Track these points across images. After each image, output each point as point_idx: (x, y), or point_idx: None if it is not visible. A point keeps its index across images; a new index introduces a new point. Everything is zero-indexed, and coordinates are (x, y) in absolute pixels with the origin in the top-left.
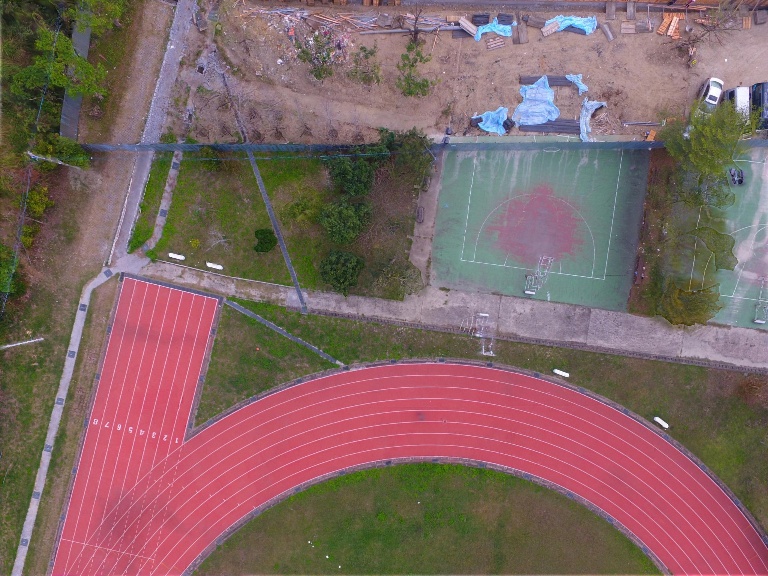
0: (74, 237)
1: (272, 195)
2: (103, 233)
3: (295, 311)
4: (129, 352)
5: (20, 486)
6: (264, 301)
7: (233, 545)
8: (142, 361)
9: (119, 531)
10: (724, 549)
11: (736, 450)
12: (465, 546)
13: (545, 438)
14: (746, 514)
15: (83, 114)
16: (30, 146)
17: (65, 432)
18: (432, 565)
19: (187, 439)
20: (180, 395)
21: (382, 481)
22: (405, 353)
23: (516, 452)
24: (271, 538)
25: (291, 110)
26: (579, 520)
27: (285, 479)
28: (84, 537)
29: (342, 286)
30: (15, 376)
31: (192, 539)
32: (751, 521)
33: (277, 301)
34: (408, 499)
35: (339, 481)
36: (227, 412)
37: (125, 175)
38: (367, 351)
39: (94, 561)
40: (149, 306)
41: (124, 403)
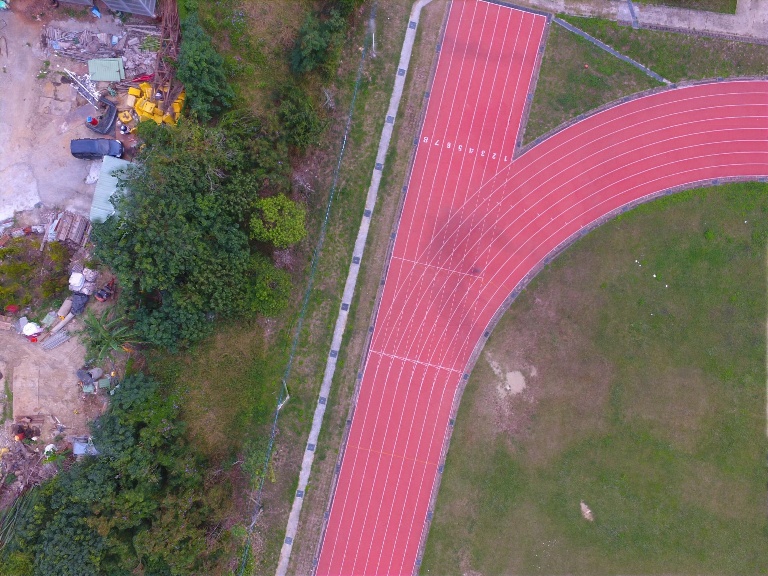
0: None
1: None
2: None
3: (626, 25)
4: (459, 69)
5: (352, 203)
6: (594, 16)
7: (561, 264)
8: (471, 79)
9: (449, 249)
10: None
11: None
12: None
13: None
14: None
15: None
16: None
17: (396, 150)
18: (759, 284)
19: (515, 158)
20: (509, 113)
21: (709, 200)
22: (733, 70)
23: None
24: (598, 257)
25: None
26: None
27: (612, 198)
28: (414, 255)
29: None
30: (348, 93)
31: (520, 258)
32: None
33: (608, 15)
34: (735, 218)
35: (666, 200)
36: (554, 131)
37: None
38: (695, 68)
39: (424, 279)
40: (478, 23)
41: (454, 121)
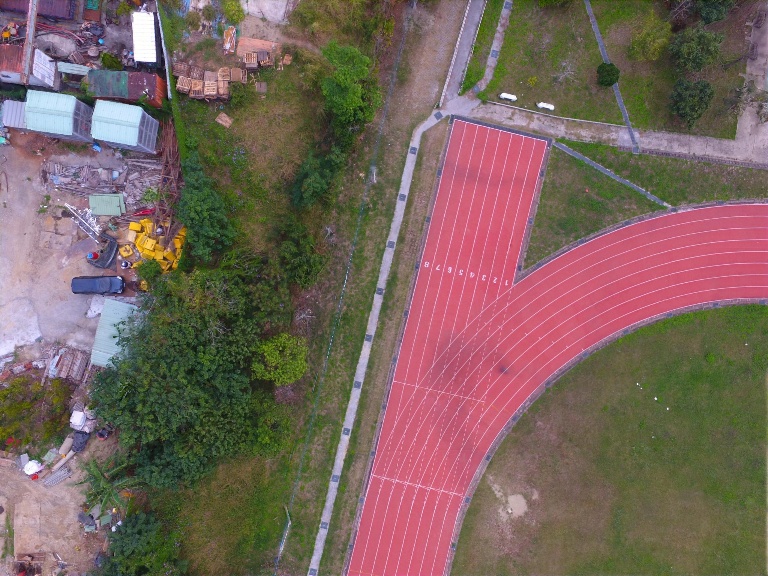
0: (406, 79)
1: (605, 33)
2: (434, 75)
3: (627, 151)
4: (460, 194)
5: (354, 328)
6: (595, 142)
7: (562, 387)
8: (472, 204)
9: (450, 373)
10: None
11: None
12: None
13: None
14: None
15: None
16: None
17: (397, 275)
18: (759, 407)
19: (516, 282)
20: (509, 237)
21: (710, 323)
22: (733, 194)
23: None
24: (599, 380)
25: None
26: None
27: (613, 321)
28: (416, 379)
29: (695, 115)
30: (349, 219)
31: (521, 381)
32: None
33: (608, 141)
34: (736, 341)
35: (667, 323)
36: (555, 255)
37: (457, 16)
38: (695, 192)
39: (426, 403)
40: (479, 148)
41: (455, 246)
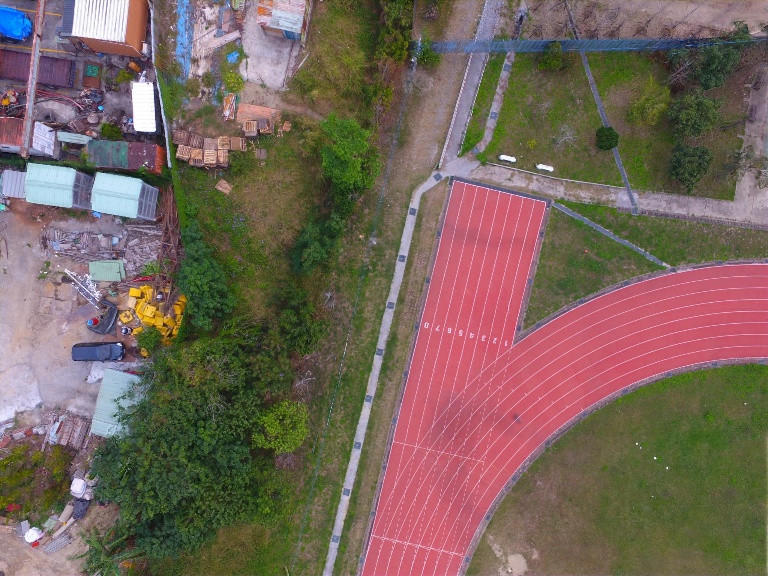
0: (406, 141)
1: (604, 95)
2: (434, 137)
3: (626, 212)
4: (459, 255)
5: (354, 389)
6: (594, 203)
7: (562, 447)
8: (472, 264)
9: (450, 434)
10: None
11: None
12: None
13: None
14: None
15: (416, 16)
16: (387, 42)
17: (396, 336)
18: (759, 466)
19: (516, 342)
20: (509, 298)
21: (709, 382)
22: (732, 254)
23: None
24: (599, 440)
25: (624, 9)
26: None
27: (612, 381)
28: (416, 440)
29: (694, 180)
30: (349, 280)
31: (521, 441)
32: None
33: (607, 202)
34: (735, 400)
35: (666, 383)
36: (555, 315)
37: (457, 78)
38: (694, 252)
39: (426, 464)
40: (478, 209)
41: (454, 306)
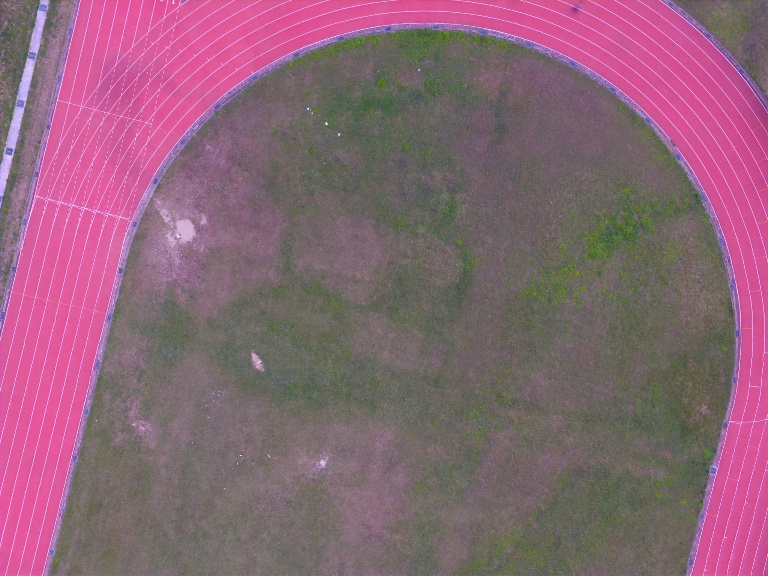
0: None
1: None
2: None
3: None
4: None
5: (15, 45)
6: None
7: (231, 110)
8: None
9: (116, 94)
10: (728, 119)
11: (741, 16)
12: (466, 115)
13: (547, 4)
14: (751, 84)
15: None
16: None
17: None
18: (432, 134)
19: (184, 1)
20: None
21: (382, 47)
22: None
23: (518, 19)
24: (270, 104)
25: None
26: (581, 89)
27: (283, 44)
28: (81, 99)
29: None
30: None
31: (190, 104)
32: (756, 91)
33: None
34: (408, 66)
35: (338, 46)
36: None
37: None
38: None
39: (91, 124)
40: None
41: None
